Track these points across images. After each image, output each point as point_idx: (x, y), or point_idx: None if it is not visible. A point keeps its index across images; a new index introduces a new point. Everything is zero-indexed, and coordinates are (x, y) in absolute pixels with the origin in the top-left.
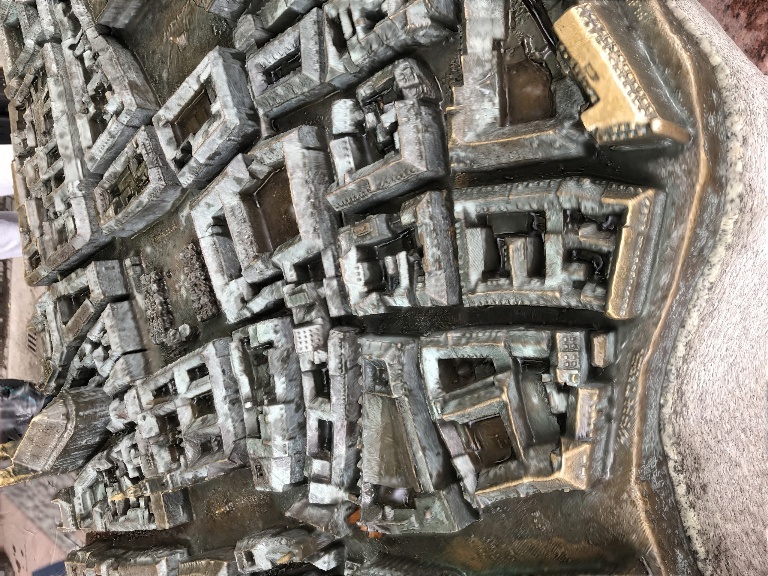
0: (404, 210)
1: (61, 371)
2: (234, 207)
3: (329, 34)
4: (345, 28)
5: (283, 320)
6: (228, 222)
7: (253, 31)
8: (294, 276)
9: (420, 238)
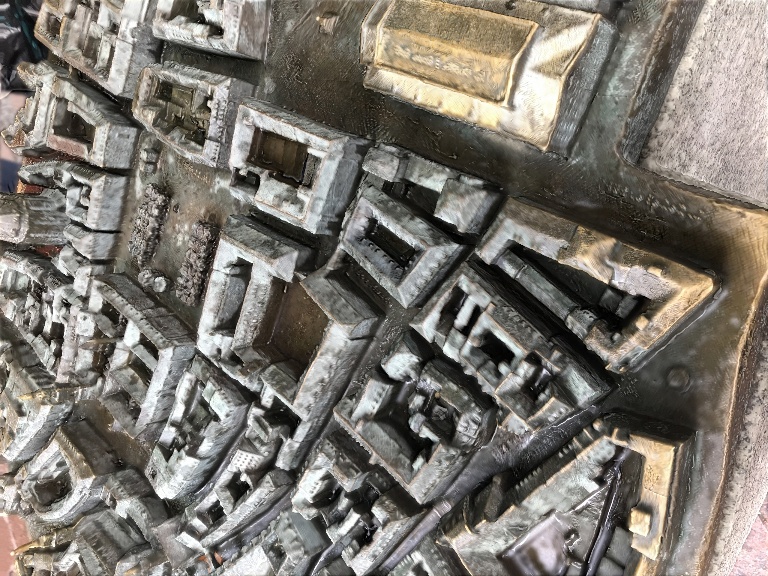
0: (380, 506)
1: (33, 148)
2: (260, 286)
3: (445, 300)
4: (462, 316)
5: (240, 406)
6: (246, 298)
7: (389, 180)
8: (269, 404)
9: (375, 535)
